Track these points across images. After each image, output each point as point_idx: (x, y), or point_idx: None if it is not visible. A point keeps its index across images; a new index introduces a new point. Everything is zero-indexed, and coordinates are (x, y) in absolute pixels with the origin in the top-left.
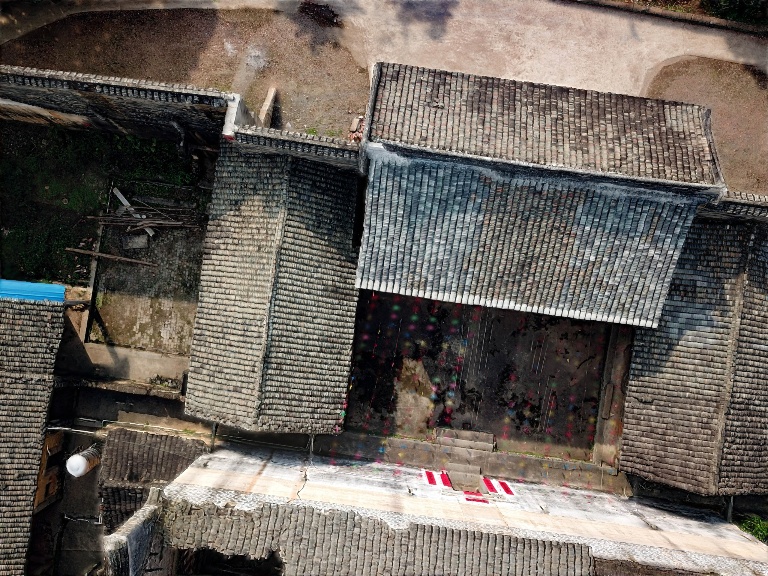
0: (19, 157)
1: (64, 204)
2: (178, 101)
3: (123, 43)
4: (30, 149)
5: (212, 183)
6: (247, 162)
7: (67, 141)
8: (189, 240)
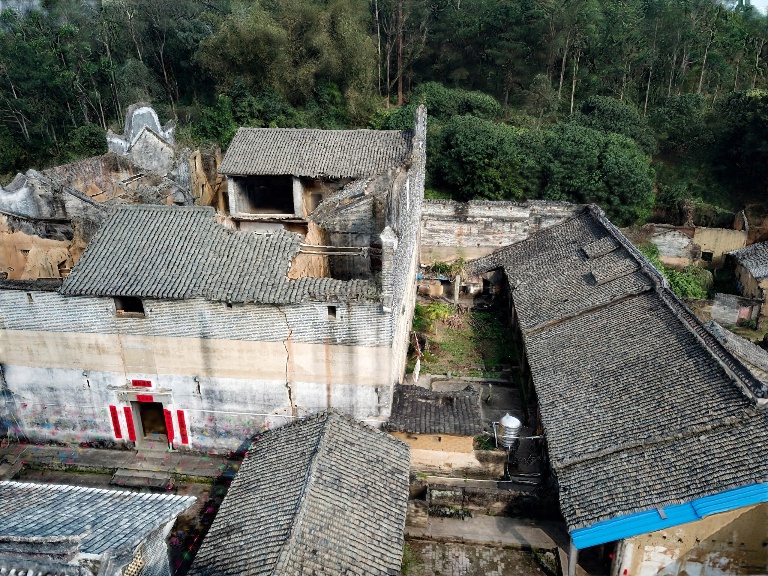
0: None
1: None
2: None
3: None
4: None
5: None
6: None
7: None
8: None
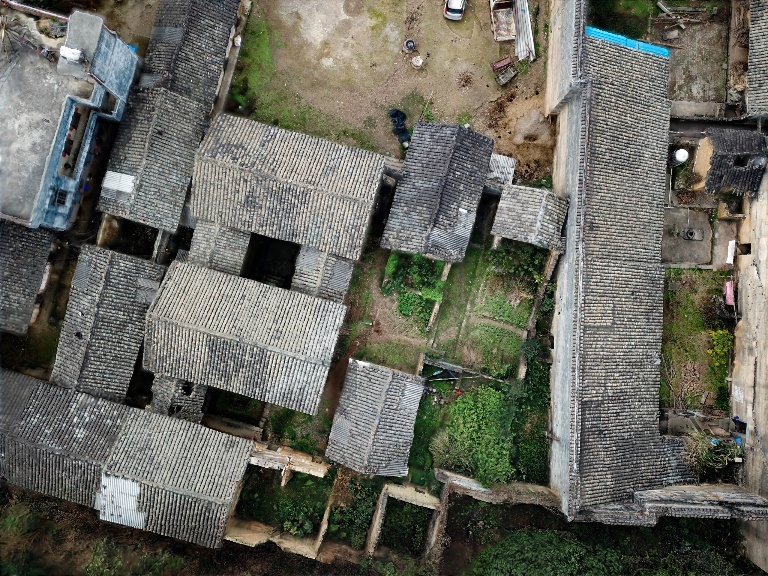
0: None
1: (632, 13)
2: None
3: None
4: None
5: None
6: None
7: None
8: (703, 31)
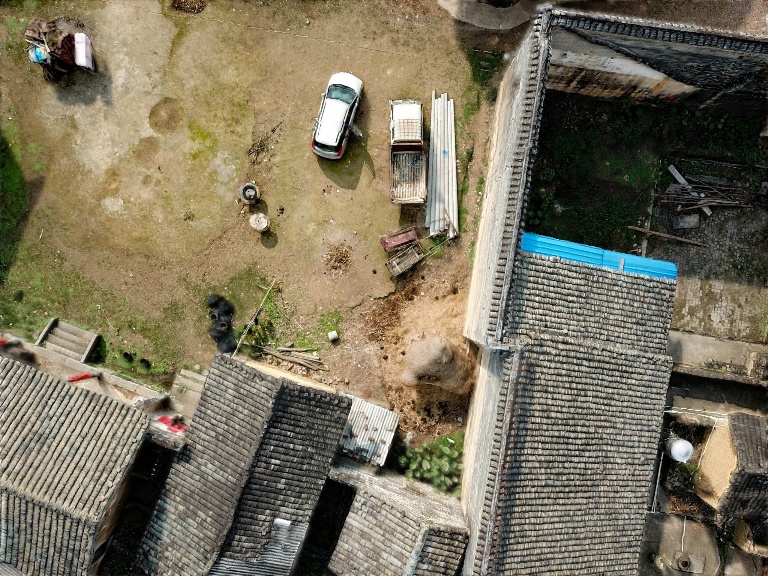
0: (577, 132)
1: (625, 181)
2: None
3: (663, 17)
4: (587, 124)
5: None
6: None
7: (638, 115)
8: (740, 220)
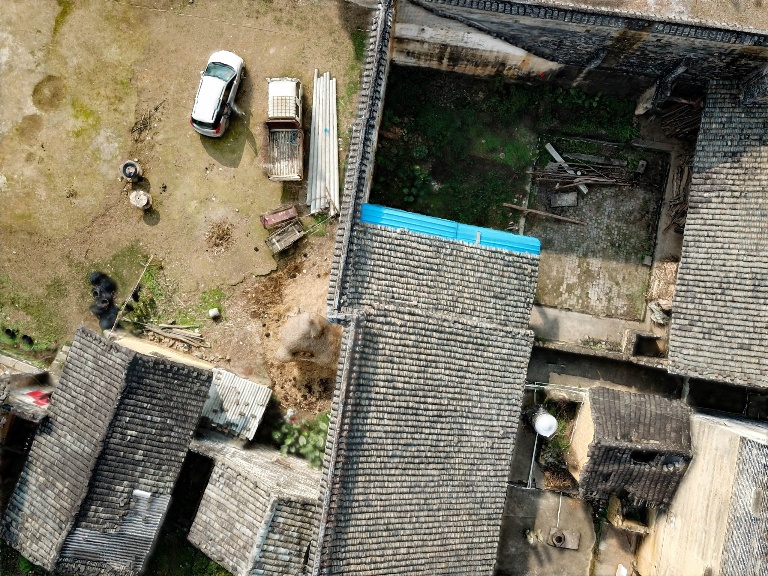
0: (454, 110)
1: (501, 159)
2: (740, 42)
3: None
4: (464, 102)
5: (646, 140)
6: (750, 112)
7: (512, 93)
8: (618, 199)
